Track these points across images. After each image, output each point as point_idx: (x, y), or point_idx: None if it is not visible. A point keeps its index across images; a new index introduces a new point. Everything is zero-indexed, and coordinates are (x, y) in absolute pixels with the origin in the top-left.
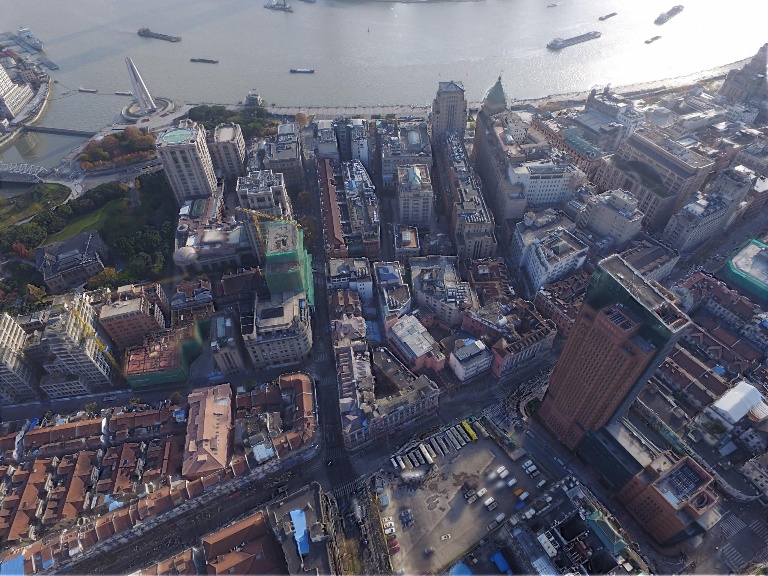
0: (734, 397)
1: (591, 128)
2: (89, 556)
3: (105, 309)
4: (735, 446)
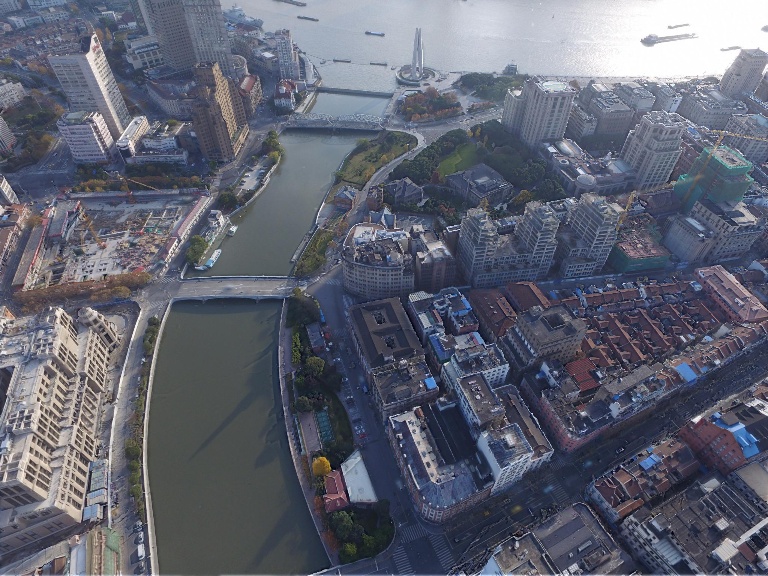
0: None
1: None
2: (713, 370)
3: None
4: None
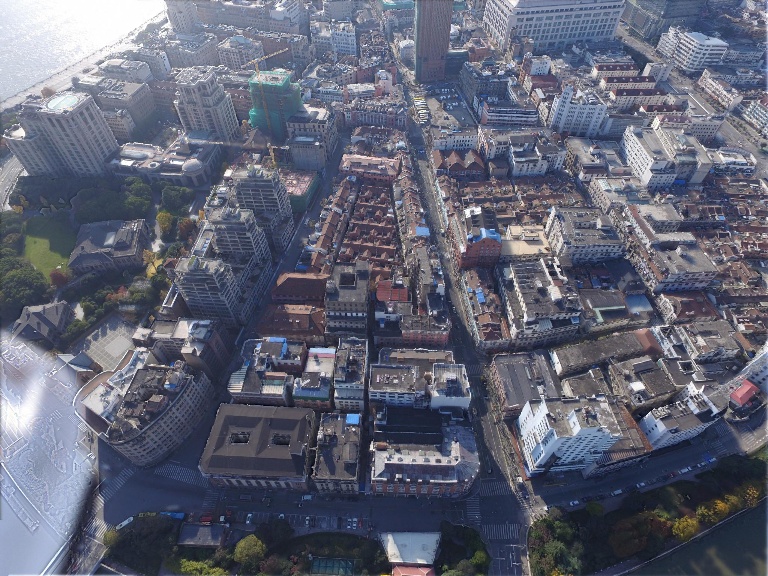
0: None
1: None
2: None
3: None
4: None
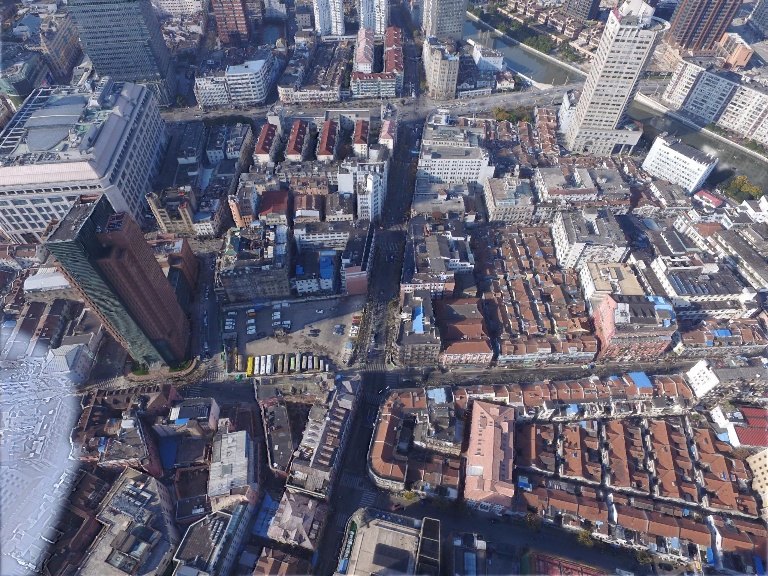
0: (49, 281)
1: None
2: None
3: None
4: None
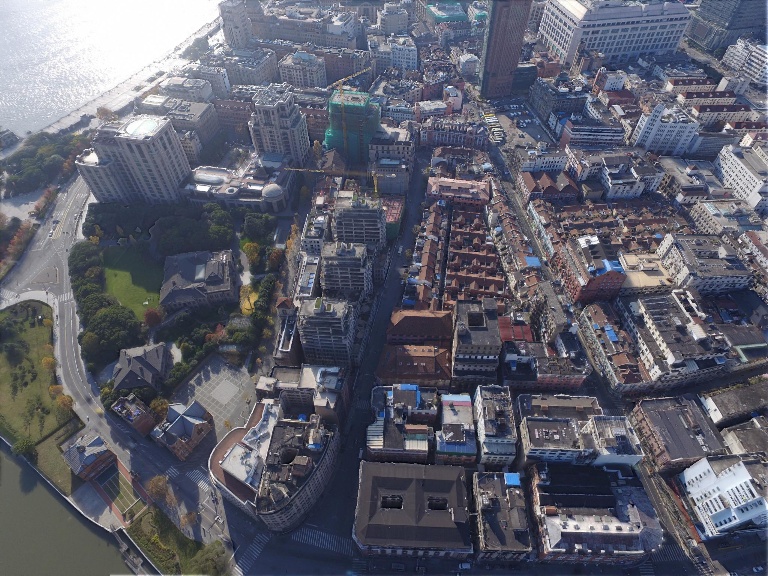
0: None
1: (303, 1)
2: None
3: None
4: None
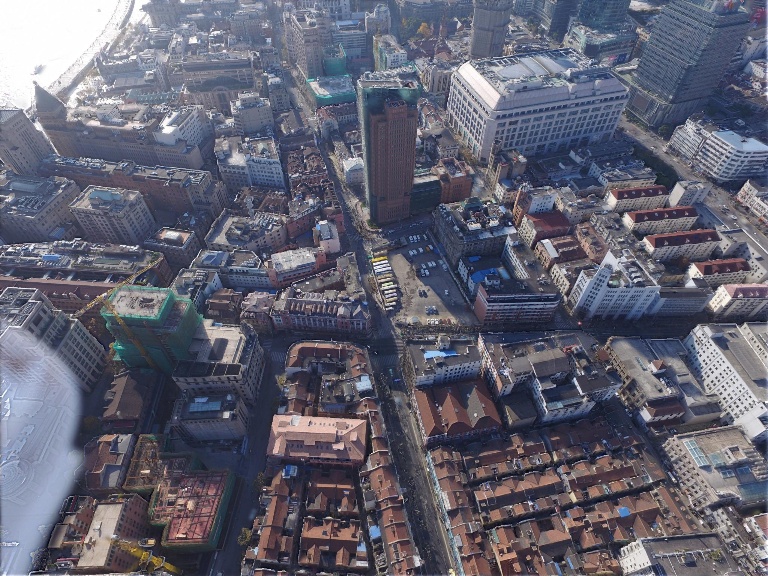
0: None
1: (139, 85)
2: None
3: (88, 560)
4: (427, 155)
